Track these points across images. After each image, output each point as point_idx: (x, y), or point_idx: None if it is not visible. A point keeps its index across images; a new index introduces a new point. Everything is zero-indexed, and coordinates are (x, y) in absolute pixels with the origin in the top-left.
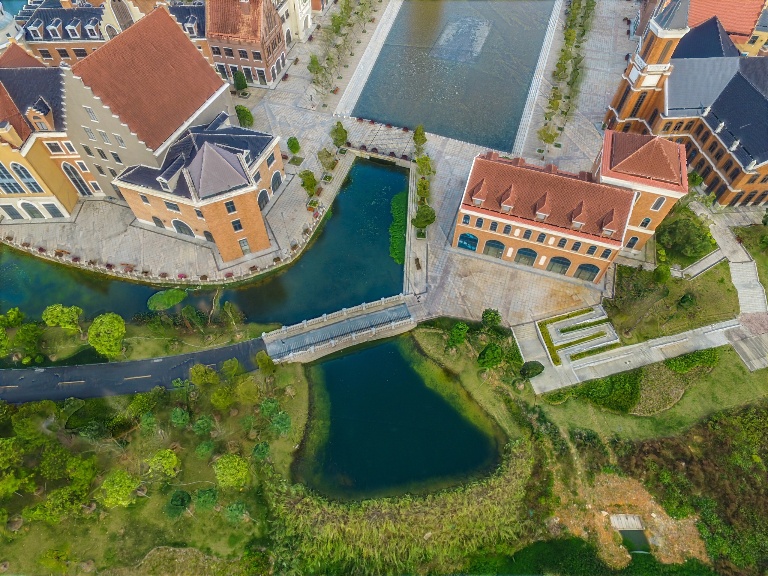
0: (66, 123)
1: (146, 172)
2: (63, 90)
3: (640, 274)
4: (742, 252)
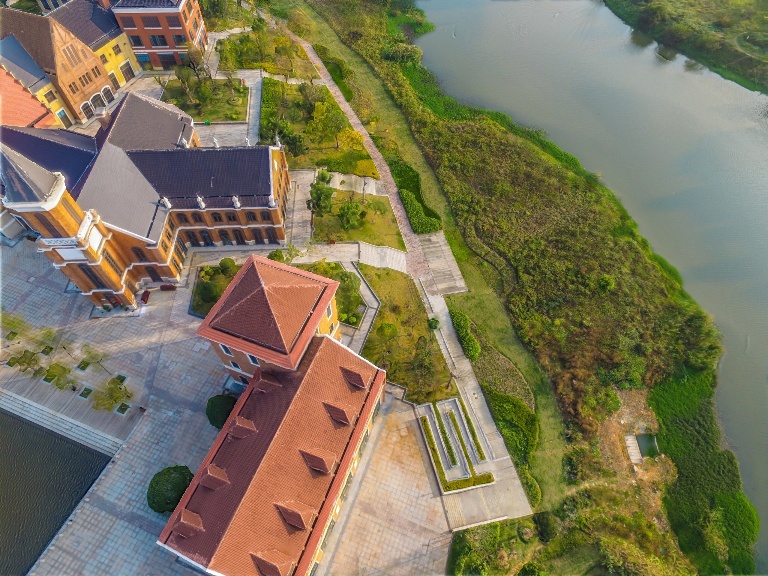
0: None
1: None
2: None
3: (371, 349)
4: (346, 246)
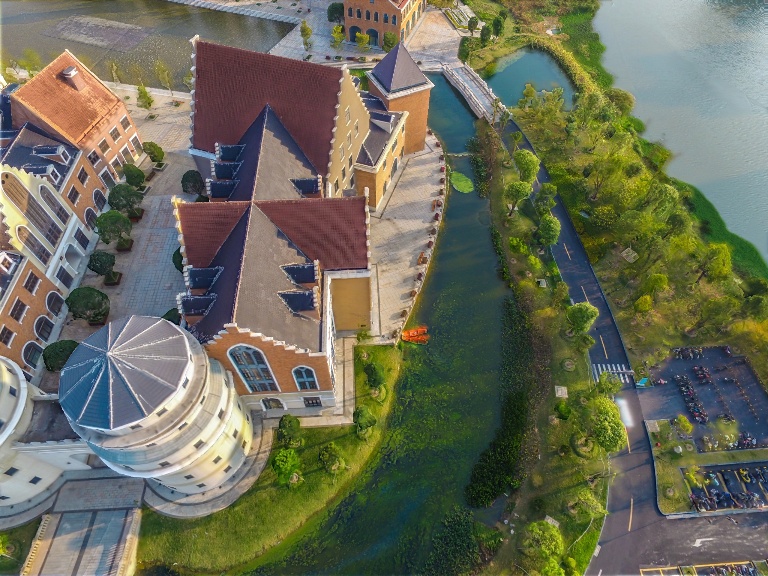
0: (331, 163)
1: (371, 141)
2: (338, 106)
3: None
4: None
